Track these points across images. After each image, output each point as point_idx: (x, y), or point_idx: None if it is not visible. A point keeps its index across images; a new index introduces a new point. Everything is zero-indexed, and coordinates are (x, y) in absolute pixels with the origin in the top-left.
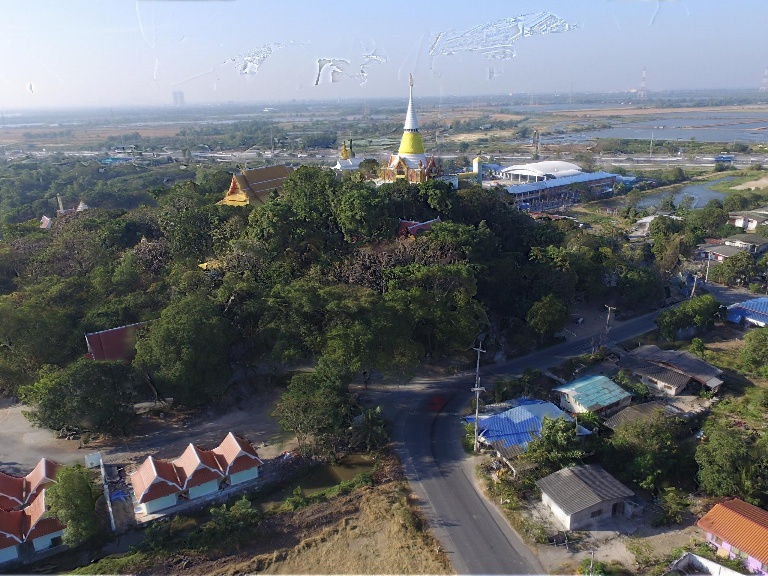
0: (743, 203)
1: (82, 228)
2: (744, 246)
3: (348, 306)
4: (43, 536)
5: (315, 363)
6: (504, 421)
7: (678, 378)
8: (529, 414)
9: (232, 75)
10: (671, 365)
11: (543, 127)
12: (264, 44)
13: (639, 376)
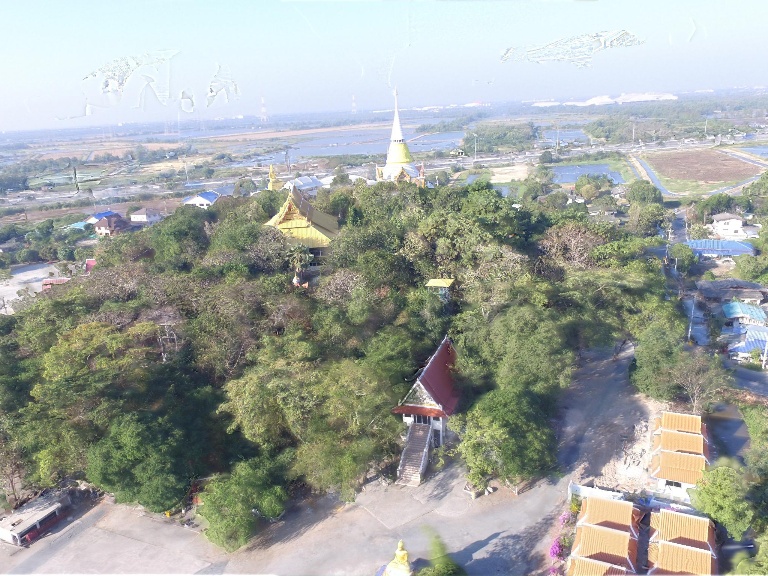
0: (542, 189)
1: (202, 281)
2: (606, 214)
3: (639, 281)
4: (714, 545)
5: (634, 339)
6: (759, 342)
7: (755, 294)
8: (764, 333)
9: (95, 94)
10: (742, 287)
11: (227, 152)
12: (121, 57)
13: (728, 300)
